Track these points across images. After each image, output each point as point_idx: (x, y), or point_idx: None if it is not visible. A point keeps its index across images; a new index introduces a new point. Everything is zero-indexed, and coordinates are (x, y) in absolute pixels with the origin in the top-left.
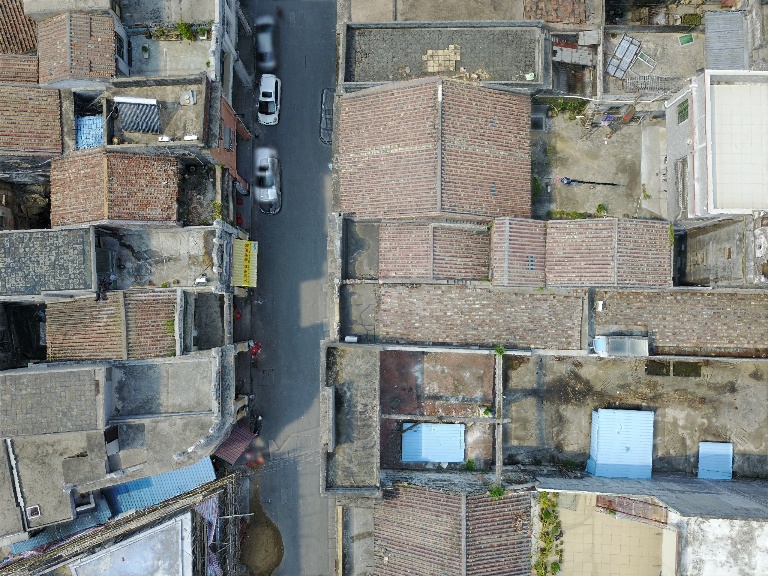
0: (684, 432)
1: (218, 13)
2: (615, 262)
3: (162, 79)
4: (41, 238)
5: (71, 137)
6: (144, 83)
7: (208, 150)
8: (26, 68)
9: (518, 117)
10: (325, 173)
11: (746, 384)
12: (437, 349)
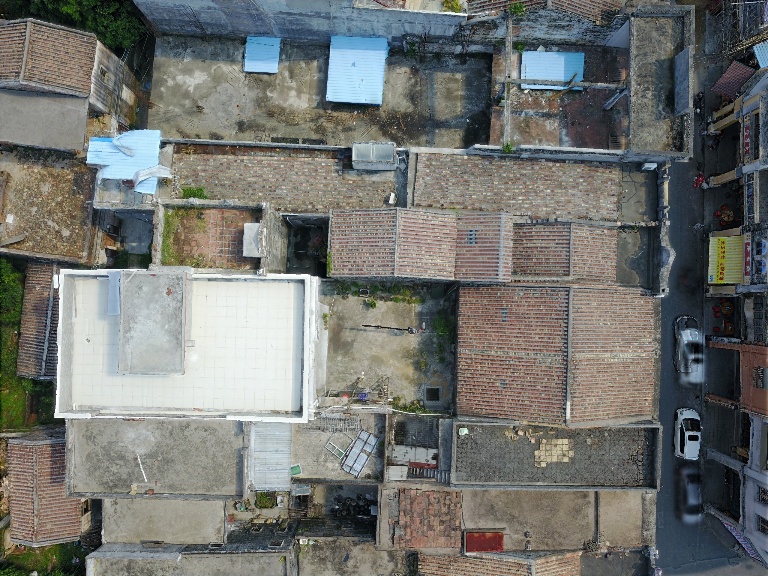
0: (291, 84)
1: None
2: (398, 231)
3: None
4: None
5: None
6: None
7: None
8: None
9: (472, 391)
10: None
11: (227, 130)
12: (573, 150)
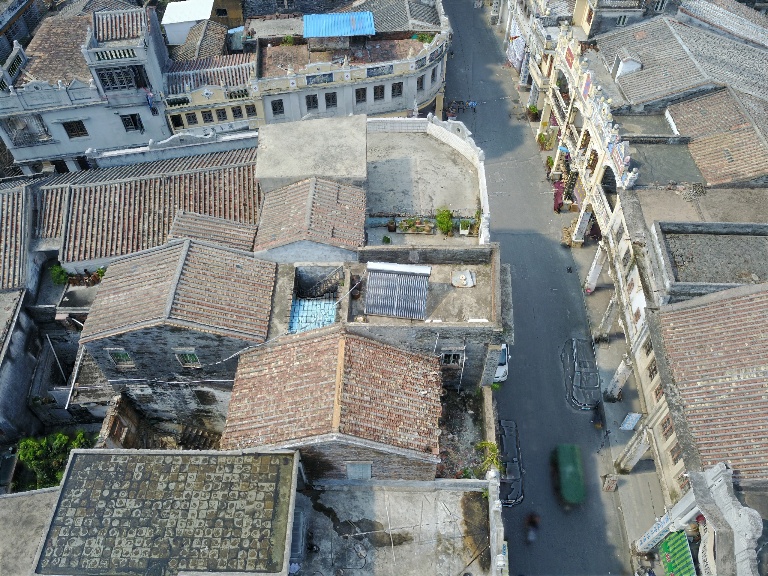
0: None
1: (487, 205)
2: None
3: (434, 249)
4: (202, 466)
5: (283, 320)
6: (404, 255)
7: (499, 345)
8: (239, 235)
9: None
10: (582, 449)
11: None
12: None
